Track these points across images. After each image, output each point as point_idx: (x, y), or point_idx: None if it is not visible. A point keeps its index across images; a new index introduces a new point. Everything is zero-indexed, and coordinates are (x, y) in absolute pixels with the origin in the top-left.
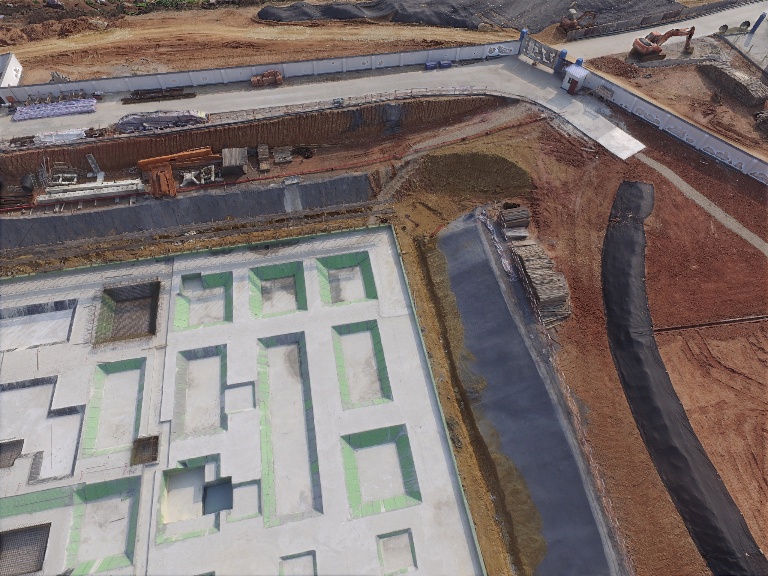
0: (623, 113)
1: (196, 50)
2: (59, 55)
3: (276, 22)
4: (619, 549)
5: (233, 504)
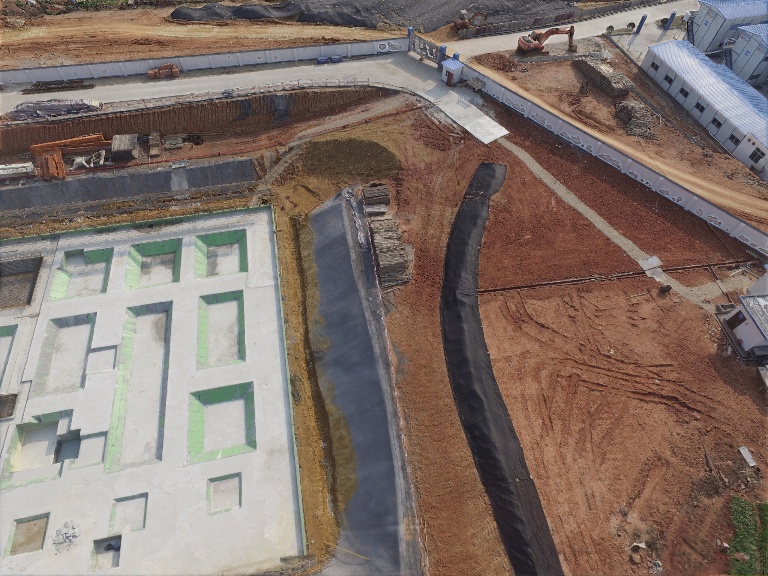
0: (495, 103)
1: (105, 46)
2: None
3: (187, 21)
4: None
5: (79, 454)
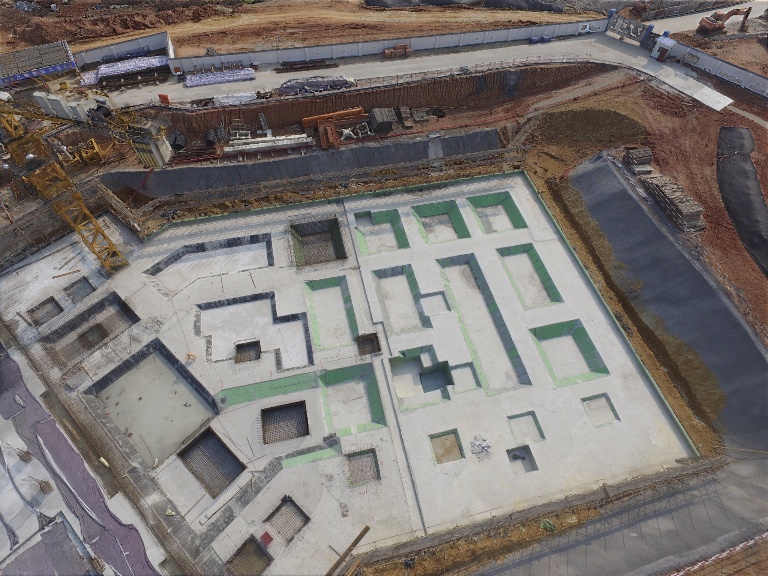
0: (707, 76)
1: (321, 31)
2: (200, 35)
3: (383, 8)
4: None
5: (454, 381)
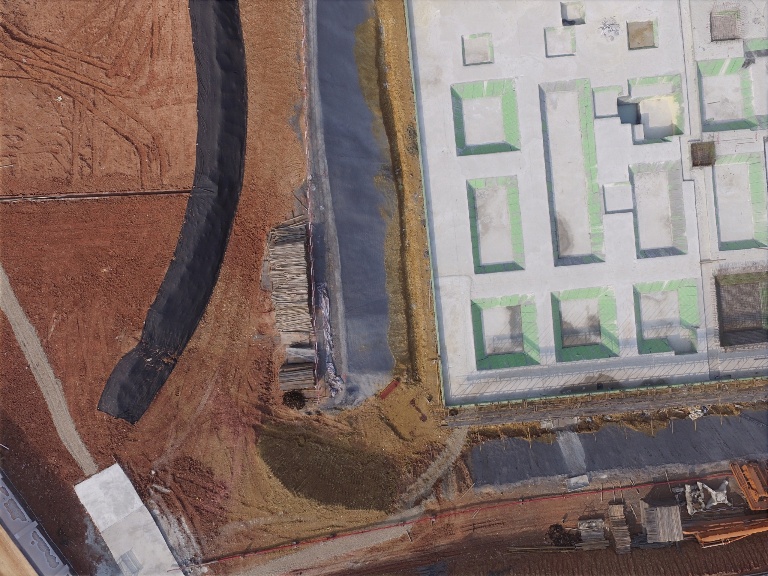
0: (78, 565)
1: None
2: None
3: None
4: (304, 1)
5: None
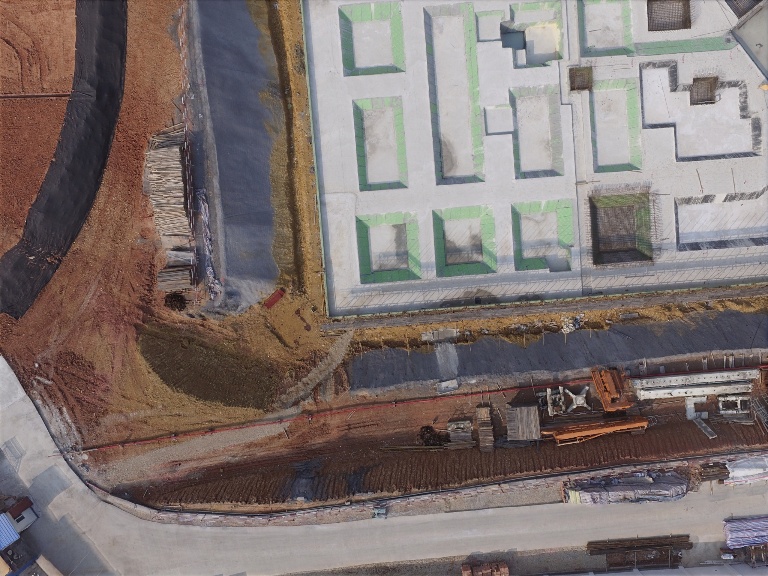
0: None
1: None
2: None
3: None
4: None
5: None
